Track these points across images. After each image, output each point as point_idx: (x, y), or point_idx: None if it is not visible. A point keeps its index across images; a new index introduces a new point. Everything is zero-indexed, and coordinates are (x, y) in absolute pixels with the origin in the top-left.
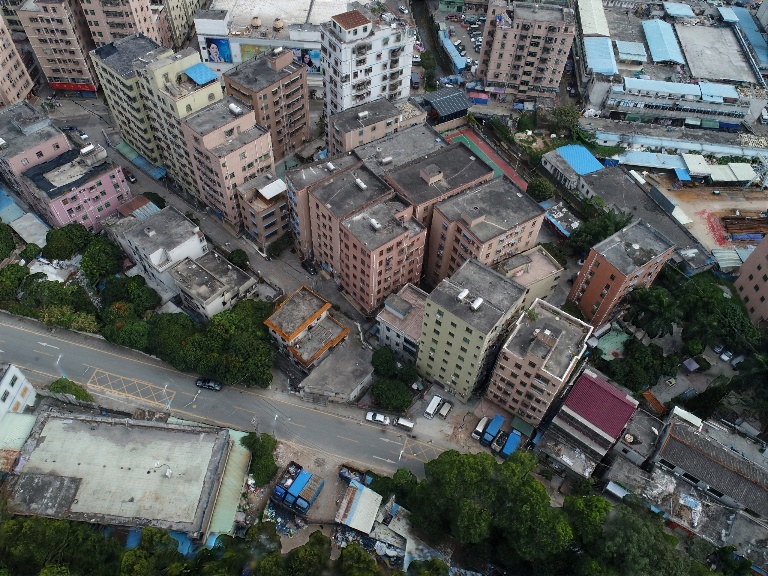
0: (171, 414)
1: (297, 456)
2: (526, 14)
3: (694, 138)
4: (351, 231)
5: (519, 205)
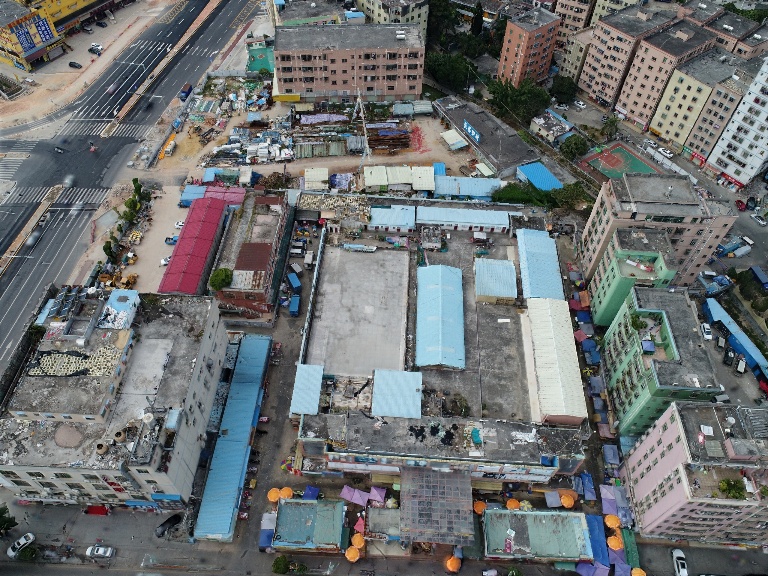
0: (739, 1)
1: (670, 7)
2: (677, 190)
3: (418, 204)
4: (714, 7)
5: (617, 25)
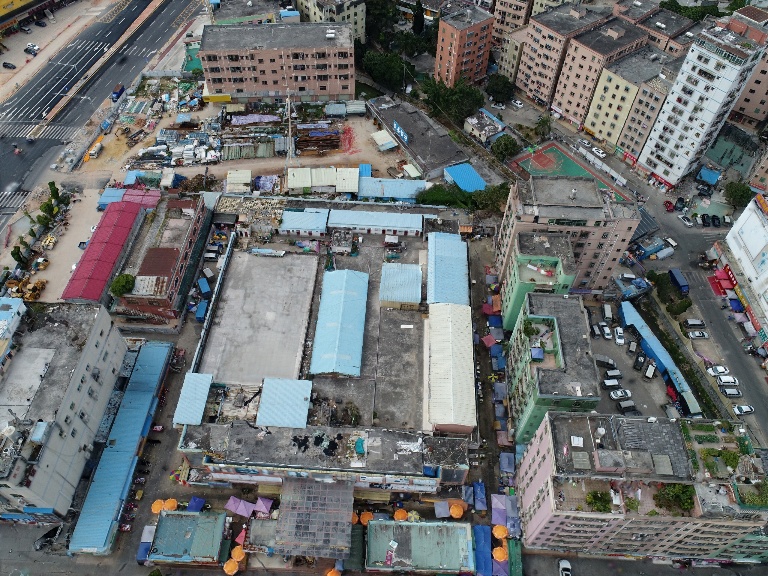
0: None
1: None
2: (583, 193)
3: (338, 206)
4: (650, 4)
5: (548, 23)
